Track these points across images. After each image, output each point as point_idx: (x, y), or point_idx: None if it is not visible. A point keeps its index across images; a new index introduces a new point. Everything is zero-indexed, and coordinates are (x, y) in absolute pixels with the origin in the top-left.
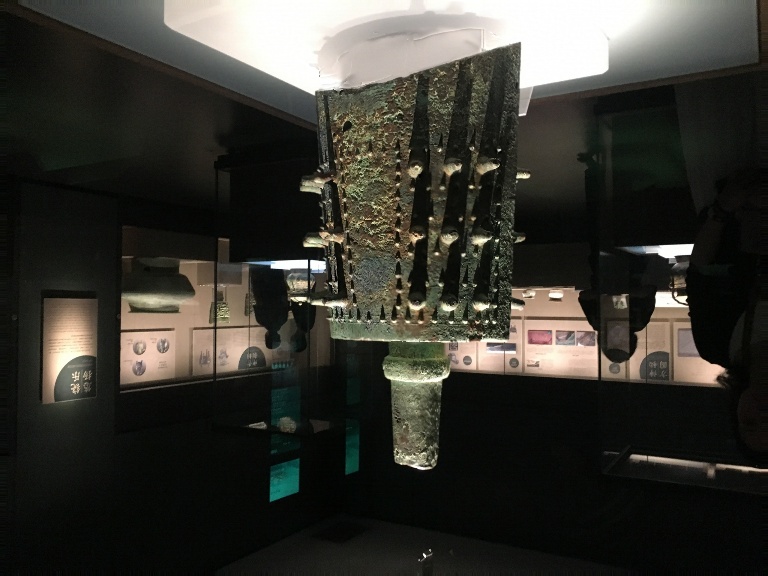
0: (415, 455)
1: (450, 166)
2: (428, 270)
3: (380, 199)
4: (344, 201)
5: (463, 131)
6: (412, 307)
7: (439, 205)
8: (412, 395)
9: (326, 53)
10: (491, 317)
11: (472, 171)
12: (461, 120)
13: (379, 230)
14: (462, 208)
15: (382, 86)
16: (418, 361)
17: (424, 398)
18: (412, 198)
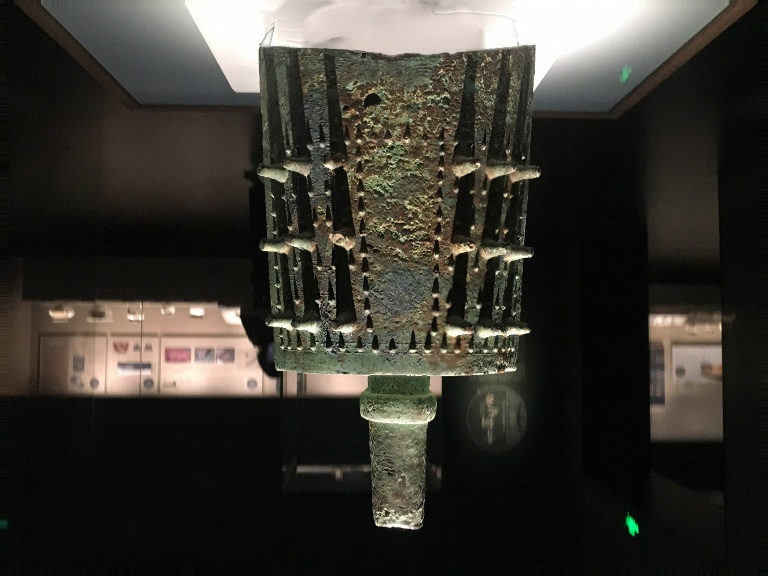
0: (412, 513)
1: (502, 168)
2: (467, 289)
3: (417, 198)
4: (360, 195)
5: (501, 130)
6: (451, 333)
7: (480, 212)
8: (411, 440)
9: (306, 1)
10: (511, 344)
11: (506, 177)
12: (500, 117)
13: (414, 236)
14: (498, 218)
15: (427, 59)
16: (422, 398)
17: (422, 442)
18: (455, 201)
